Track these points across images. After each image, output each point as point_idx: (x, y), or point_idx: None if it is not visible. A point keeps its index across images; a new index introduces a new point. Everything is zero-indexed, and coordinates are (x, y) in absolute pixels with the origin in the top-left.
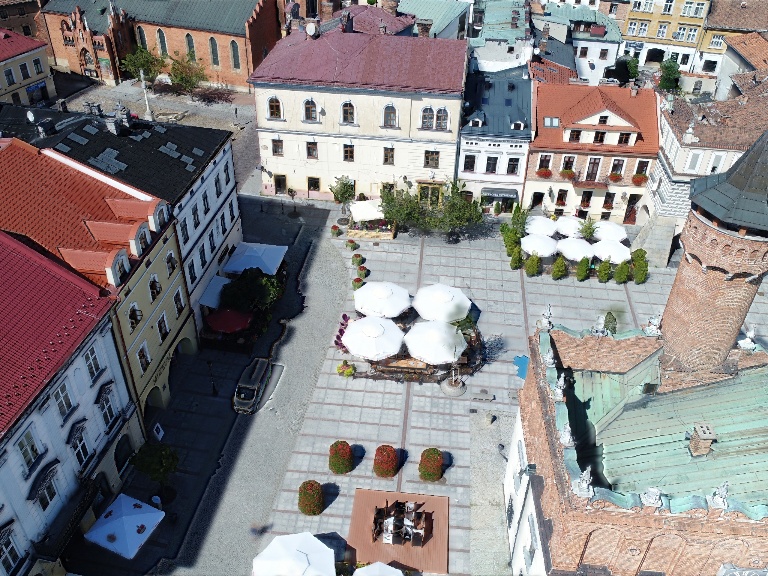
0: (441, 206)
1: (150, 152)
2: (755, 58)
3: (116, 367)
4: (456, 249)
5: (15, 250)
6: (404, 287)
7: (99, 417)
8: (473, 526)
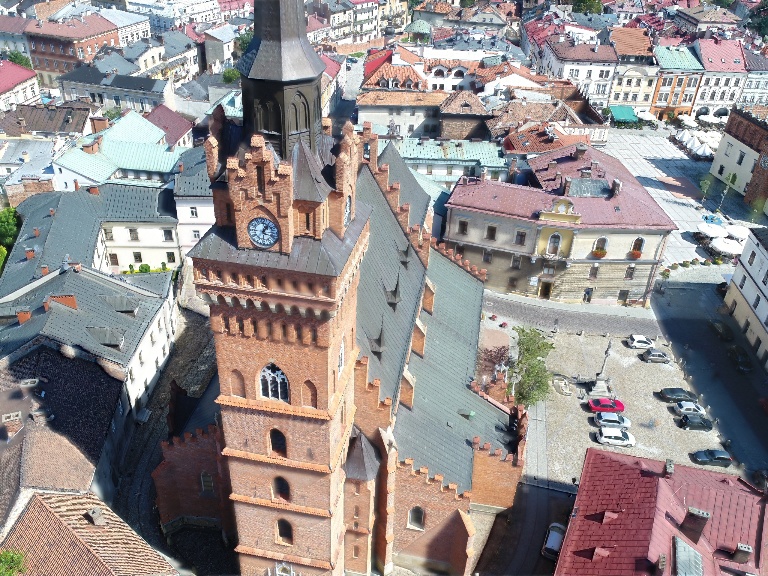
0: None
1: None
2: (409, 102)
3: None
4: None
5: None
6: (692, 251)
7: None
8: None
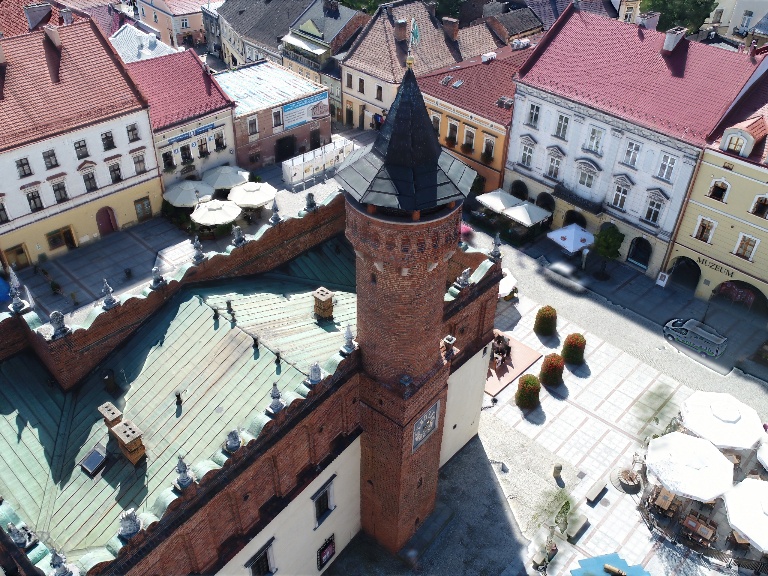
0: None
1: None
2: None
3: (679, 196)
4: None
5: None
6: None
7: None
8: None
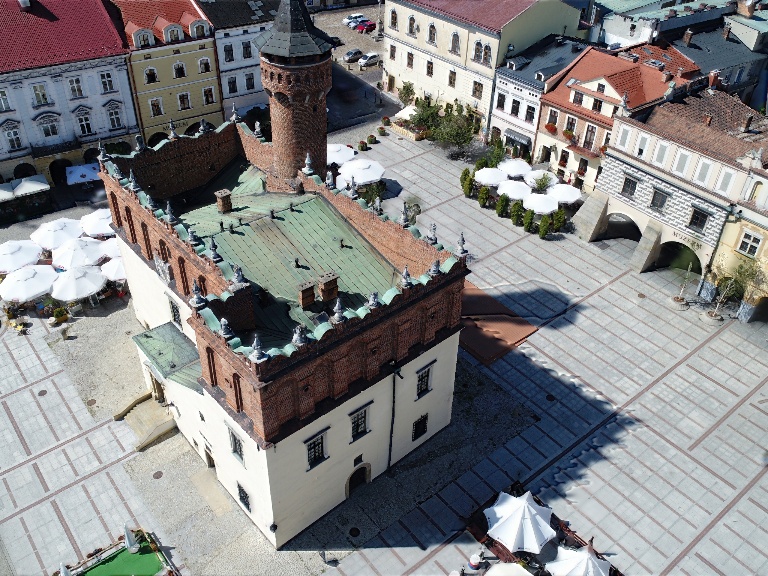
0: (480, 136)
1: (240, 1)
2: None
3: (127, 97)
4: (446, 162)
5: (101, 8)
6: None
7: (106, 117)
8: None
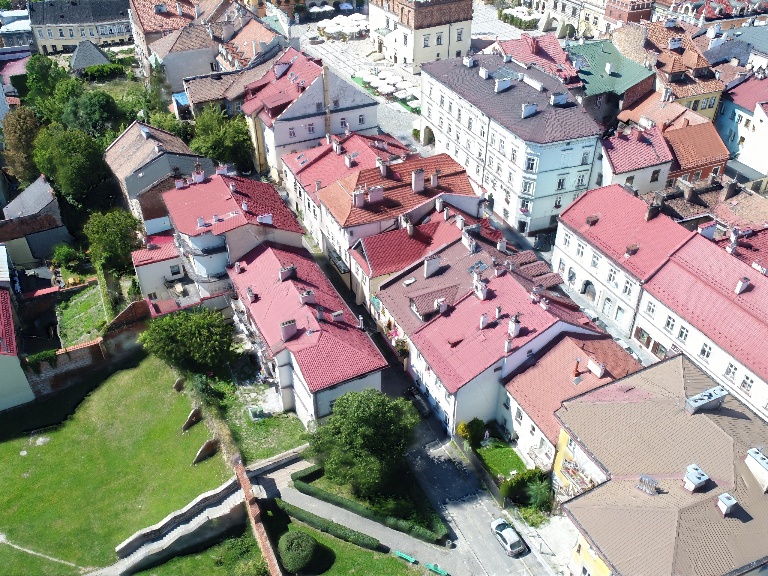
0: None
1: None
2: None
3: None
4: None
5: None
6: None
7: None
8: None
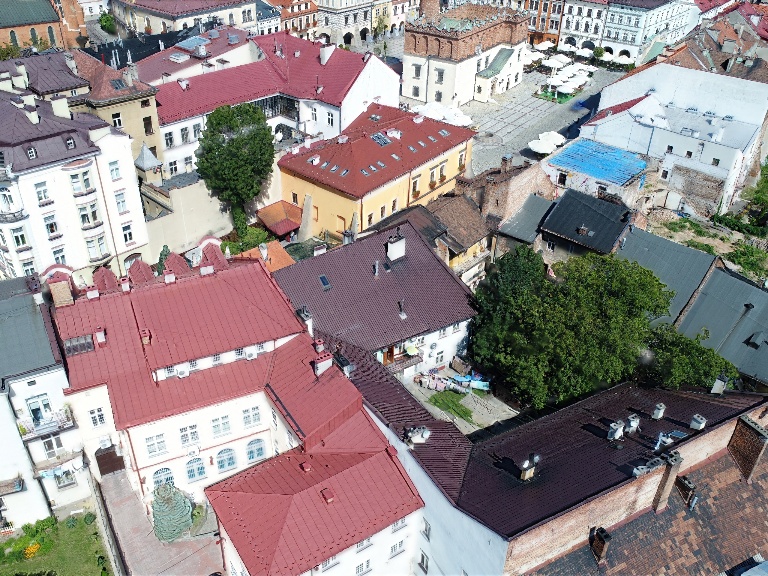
0: None
1: None
2: None
3: None
4: None
5: None
6: None
7: None
8: (410, 103)
